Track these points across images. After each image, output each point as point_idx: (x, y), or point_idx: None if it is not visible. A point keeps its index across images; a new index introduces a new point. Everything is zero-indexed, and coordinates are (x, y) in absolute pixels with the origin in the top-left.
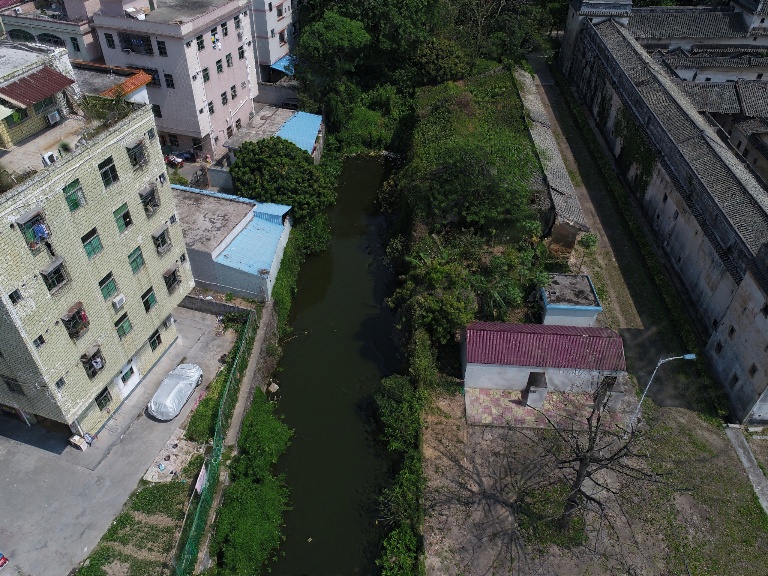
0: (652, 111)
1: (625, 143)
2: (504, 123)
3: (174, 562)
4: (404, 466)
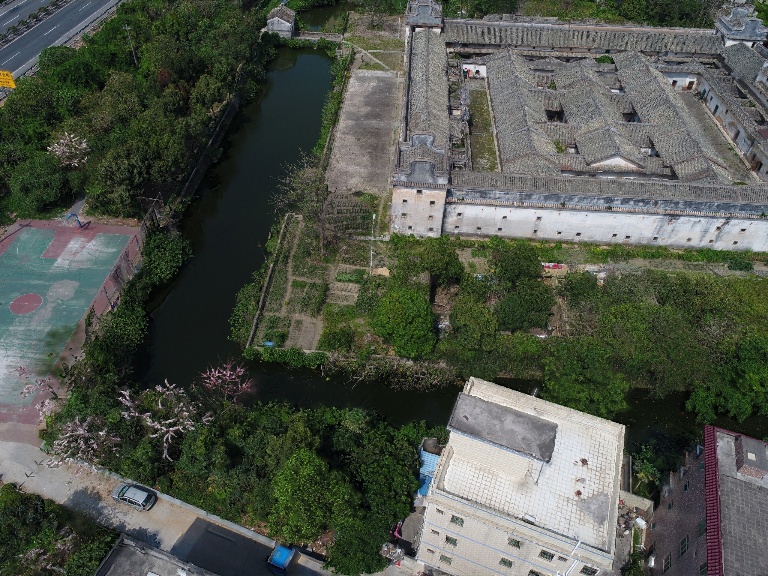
0: None
1: None
2: None
3: None
4: None
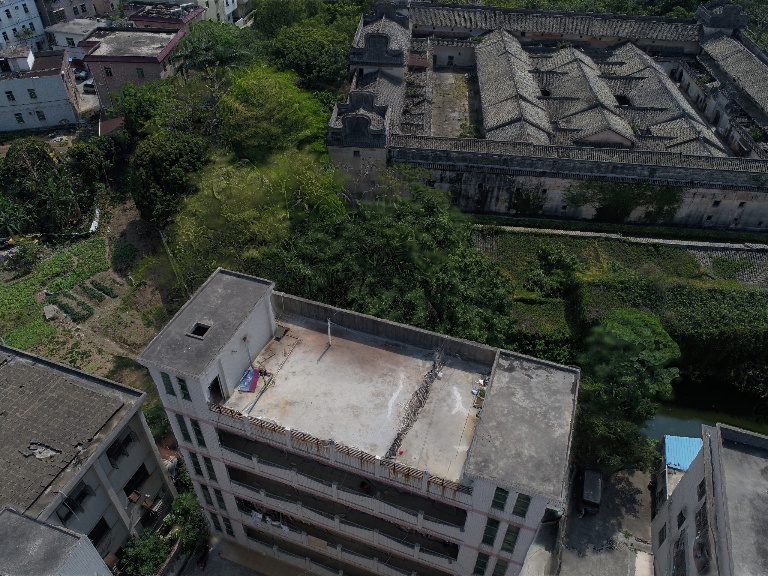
0: (653, 165)
1: (606, 203)
2: (631, 261)
3: None
4: None
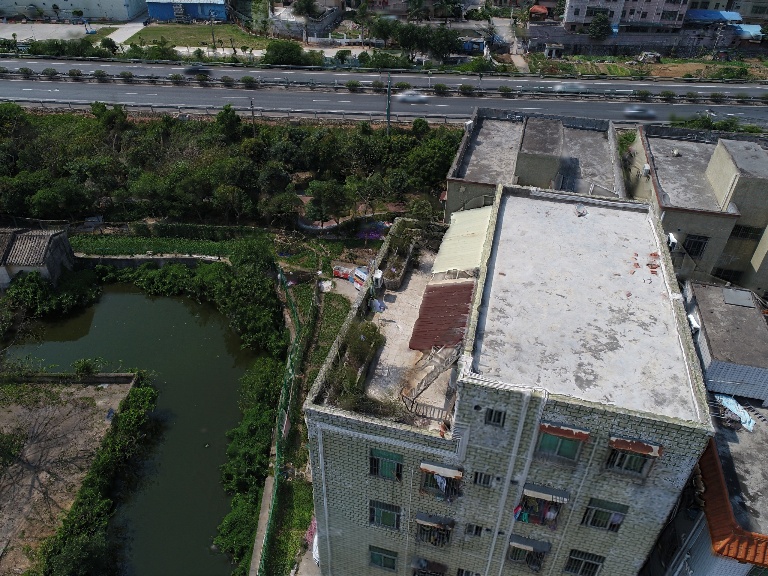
0: None
1: None
2: None
3: (295, 378)
4: None
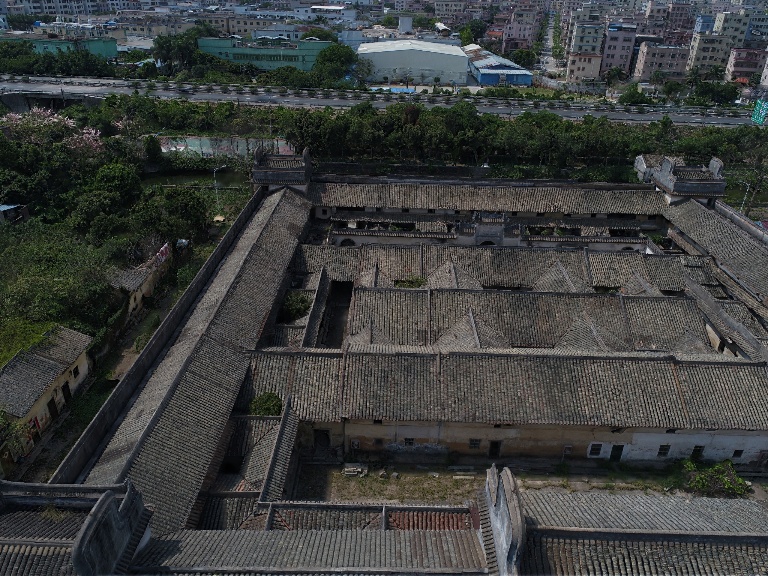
0: None
1: None
2: None
3: None
4: None
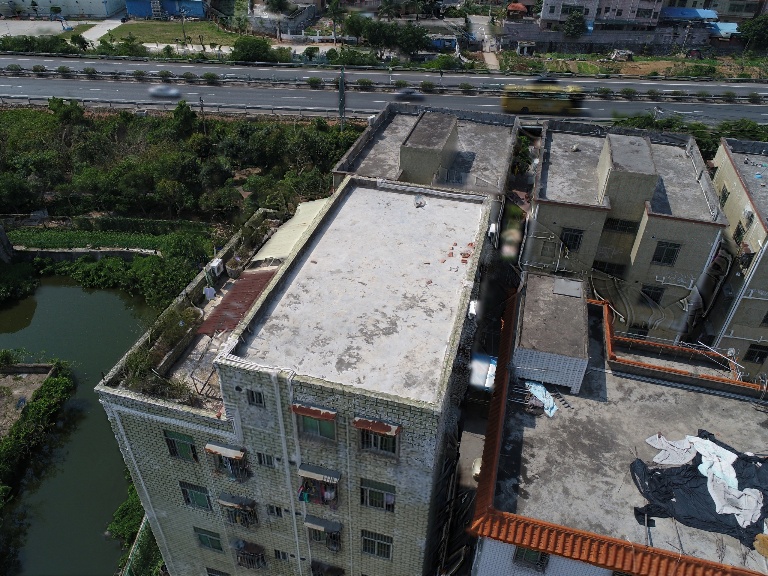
0: None
1: None
2: None
3: None
4: (4, 467)
